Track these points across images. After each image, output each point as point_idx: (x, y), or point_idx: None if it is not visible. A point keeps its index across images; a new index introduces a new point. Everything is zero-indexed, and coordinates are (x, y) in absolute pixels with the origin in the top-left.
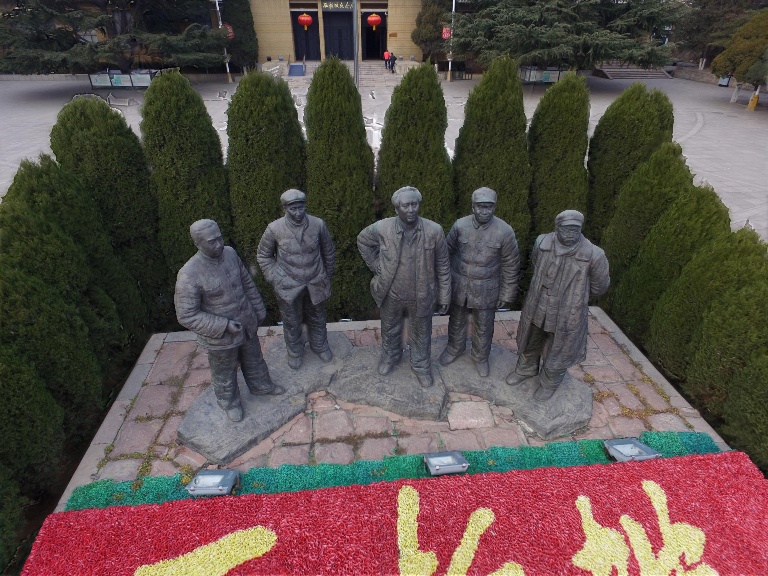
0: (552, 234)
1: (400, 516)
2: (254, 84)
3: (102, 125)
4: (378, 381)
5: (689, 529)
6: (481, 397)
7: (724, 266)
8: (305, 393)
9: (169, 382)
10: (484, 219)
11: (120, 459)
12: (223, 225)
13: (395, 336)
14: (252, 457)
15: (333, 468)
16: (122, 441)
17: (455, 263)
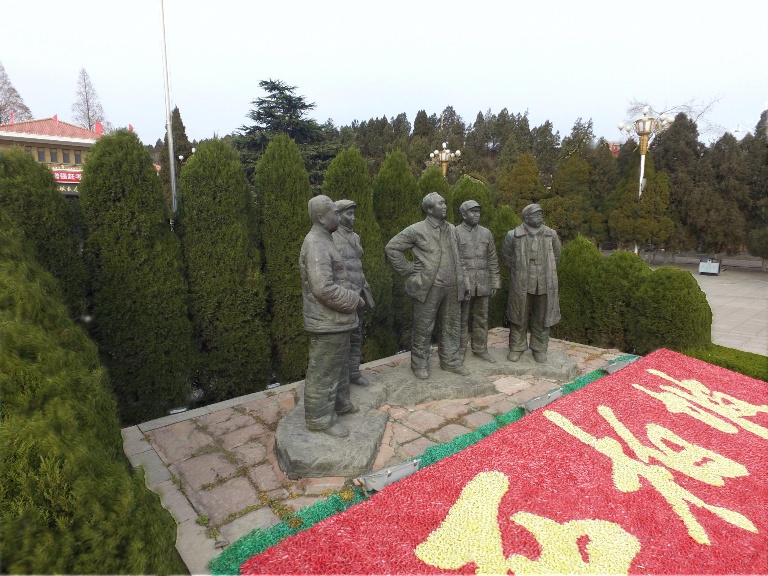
0: (520, 226)
1: (563, 428)
2: (218, 148)
3: (36, 174)
4: (426, 383)
5: (689, 381)
6: (505, 374)
7: (582, 257)
8: (375, 408)
9: (203, 452)
10: (477, 221)
11: (235, 518)
12: (182, 291)
13: (429, 336)
14: (385, 461)
15: (468, 436)
16: (215, 506)
17: None
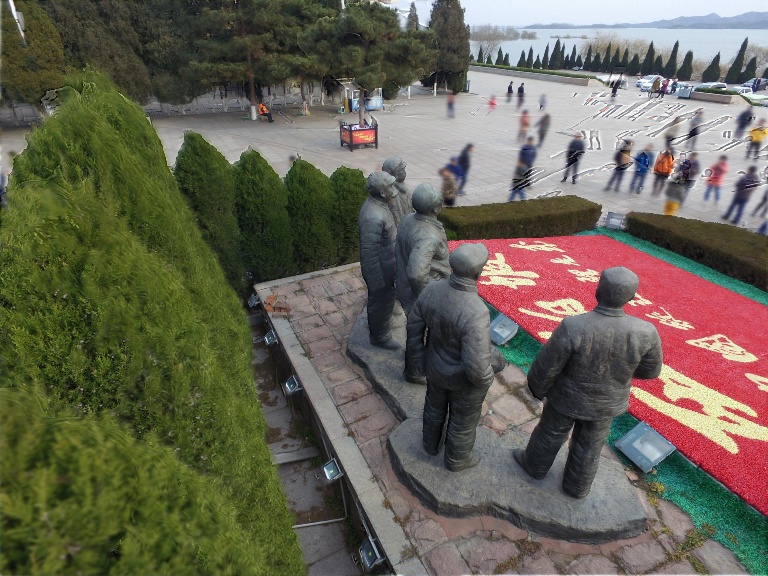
0: None
1: None
2: None
3: None
4: None
5: None
6: None
7: (319, 183)
8: None
9: None
10: None
11: None
12: None
13: None
14: None
15: None
16: None
17: (386, 253)
